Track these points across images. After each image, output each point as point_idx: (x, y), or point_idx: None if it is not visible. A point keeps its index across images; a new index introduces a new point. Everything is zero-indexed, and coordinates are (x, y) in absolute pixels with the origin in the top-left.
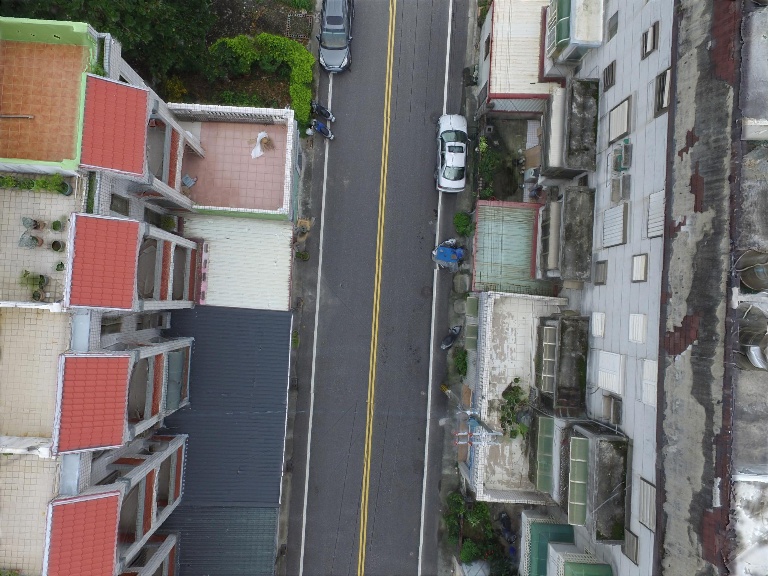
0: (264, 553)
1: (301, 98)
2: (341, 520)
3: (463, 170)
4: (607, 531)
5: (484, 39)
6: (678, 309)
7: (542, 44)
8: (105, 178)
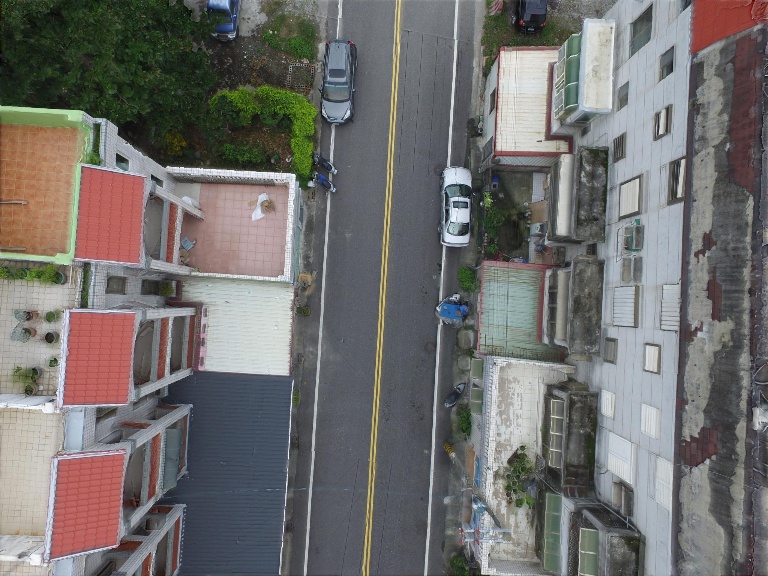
0: None
1: (303, 152)
2: None
3: (468, 225)
4: None
5: (489, 91)
6: (694, 418)
7: (549, 101)
8: (100, 268)
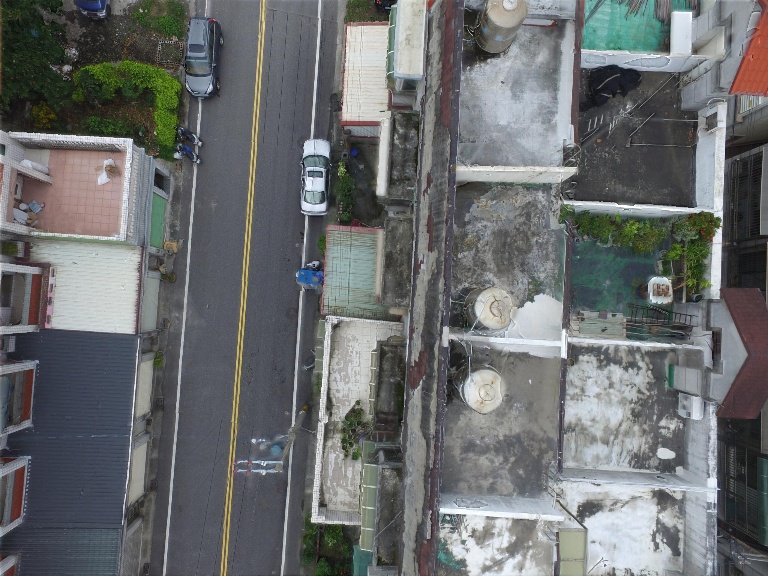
0: (105, 574)
1: (165, 124)
2: (204, 539)
3: (323, 194)
4: (388, 557)
5: None
6: (417, 344)
7: None
8: None
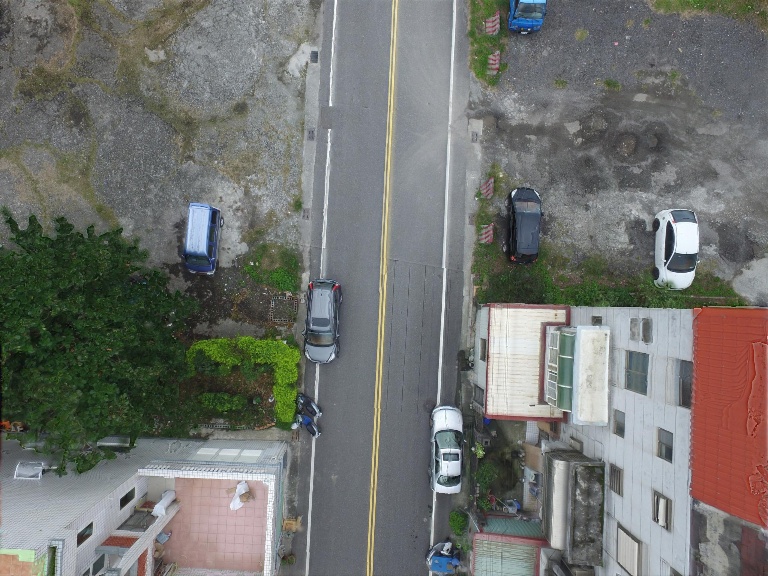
0: None
1: (285, 400)
2: None
3: (459, 476)
4: None
5: (480, 332)
6: None
7: (542, 362)
8: None
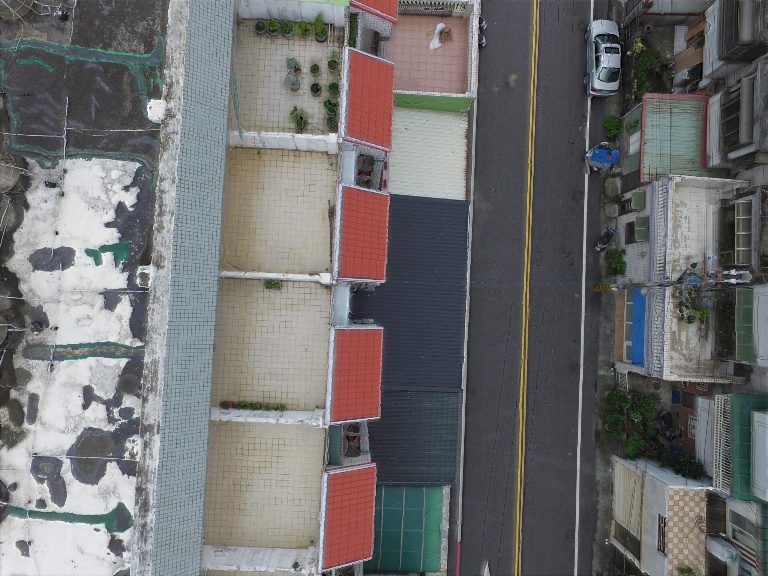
0: (449, 437)
1: None
2: (499, 421)
3: (618, 72)
4: None
5: None
6: None
7: None
8: None
